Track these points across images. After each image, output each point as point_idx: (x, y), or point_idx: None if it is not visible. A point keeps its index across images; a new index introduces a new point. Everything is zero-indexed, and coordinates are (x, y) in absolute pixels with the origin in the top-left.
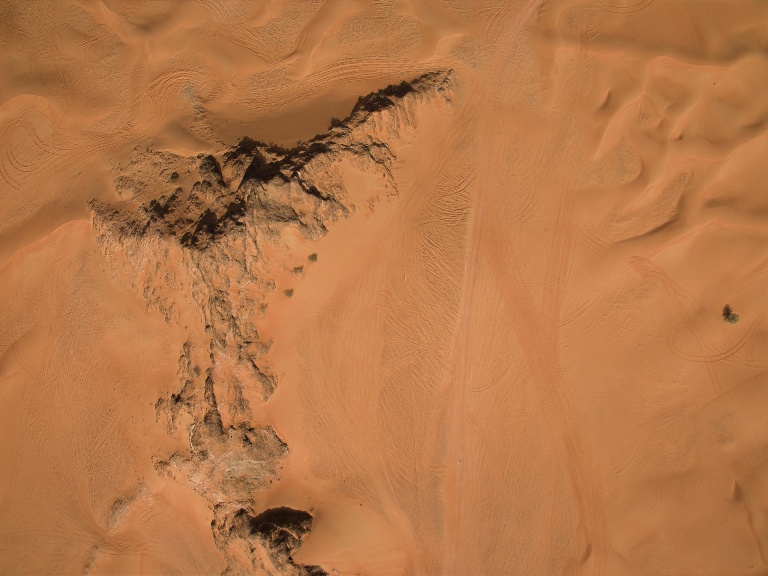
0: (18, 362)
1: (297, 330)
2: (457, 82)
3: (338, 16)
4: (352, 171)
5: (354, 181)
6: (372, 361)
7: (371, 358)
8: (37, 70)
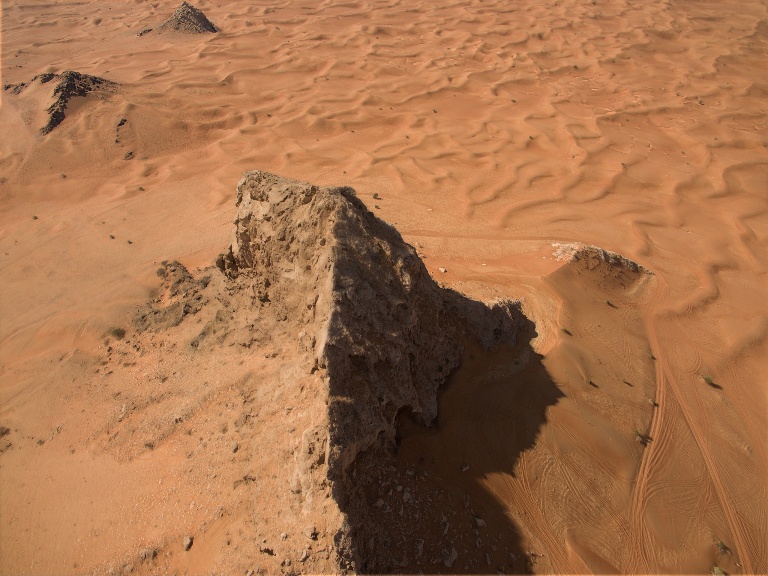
0: None
1: None
2: None
3: None
4: None
5: None
6: None
7: None
8: None
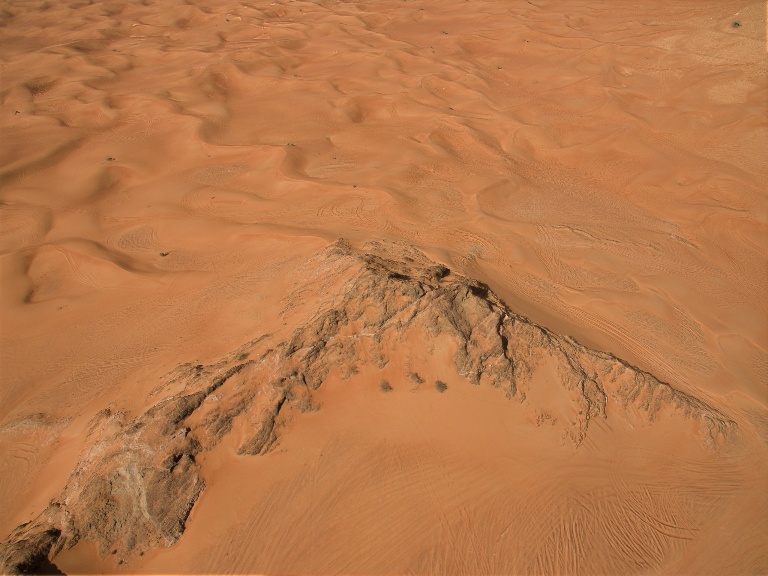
0: (176, 279)
1: (349, 428)
2: (734, 436)
3: (639, 304)
4: (552, 373)
5: (546, 381)
6: (366, 573)
7: (370, 567)
8: (404, 192)
